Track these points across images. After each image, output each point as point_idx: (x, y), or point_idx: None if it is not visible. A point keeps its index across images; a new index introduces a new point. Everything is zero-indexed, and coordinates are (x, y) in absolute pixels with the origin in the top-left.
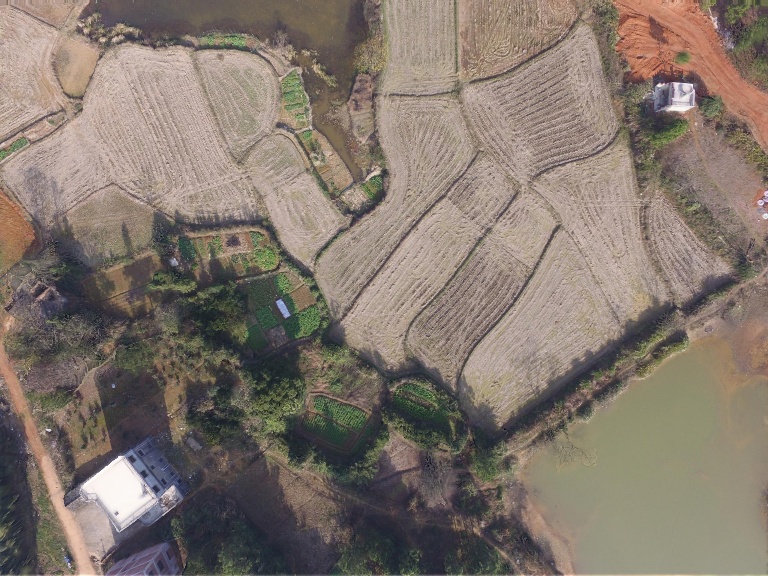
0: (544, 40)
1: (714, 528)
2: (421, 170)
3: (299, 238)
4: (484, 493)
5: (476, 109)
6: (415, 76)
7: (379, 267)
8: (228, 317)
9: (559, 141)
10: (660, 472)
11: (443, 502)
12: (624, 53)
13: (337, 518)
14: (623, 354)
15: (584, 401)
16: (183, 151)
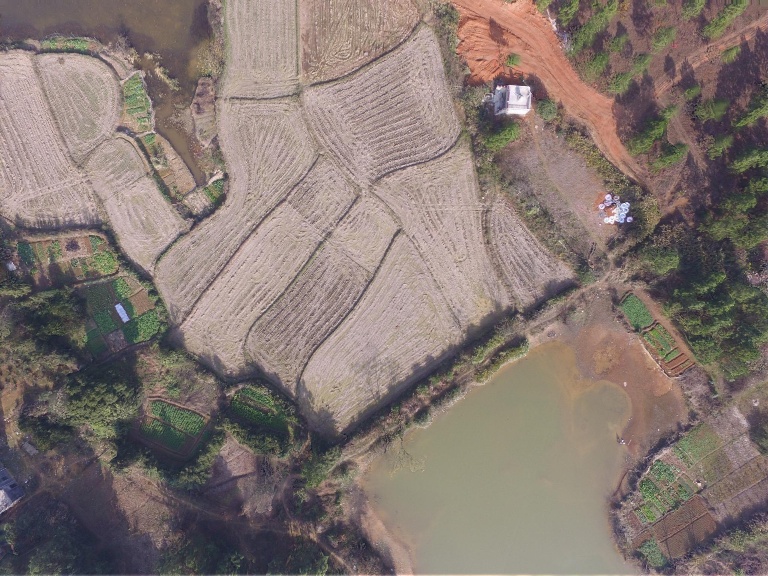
0: (386, 43)
1: (558, 534)
2: (261, 174)
3: (139, 242)
4: (322, 498)
5: (316, 112)
6: (256, 79)
7: (219, 271)
8: (62, 322)
9: (400, 144)
10: (503, 478)
11: (269, 508)
12: (464, 56)
13: (170, 523)
14: (462, 359)
15: (422, 406)
16: (23, 155)
